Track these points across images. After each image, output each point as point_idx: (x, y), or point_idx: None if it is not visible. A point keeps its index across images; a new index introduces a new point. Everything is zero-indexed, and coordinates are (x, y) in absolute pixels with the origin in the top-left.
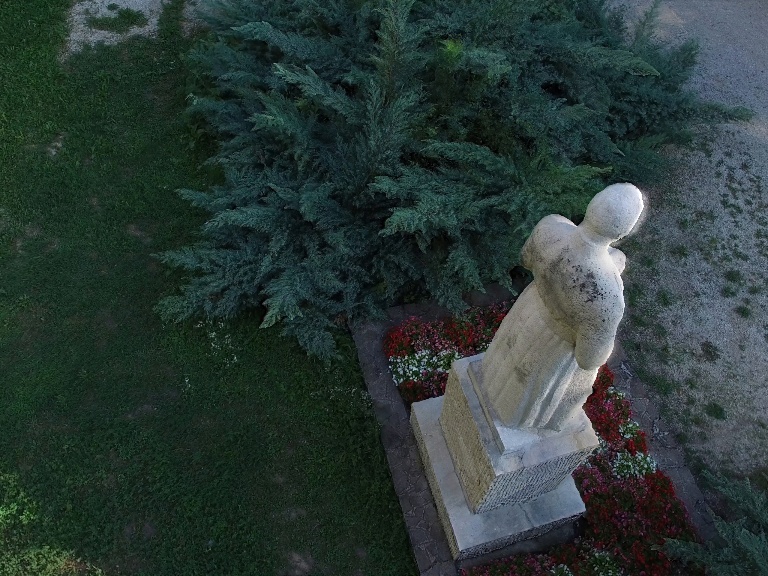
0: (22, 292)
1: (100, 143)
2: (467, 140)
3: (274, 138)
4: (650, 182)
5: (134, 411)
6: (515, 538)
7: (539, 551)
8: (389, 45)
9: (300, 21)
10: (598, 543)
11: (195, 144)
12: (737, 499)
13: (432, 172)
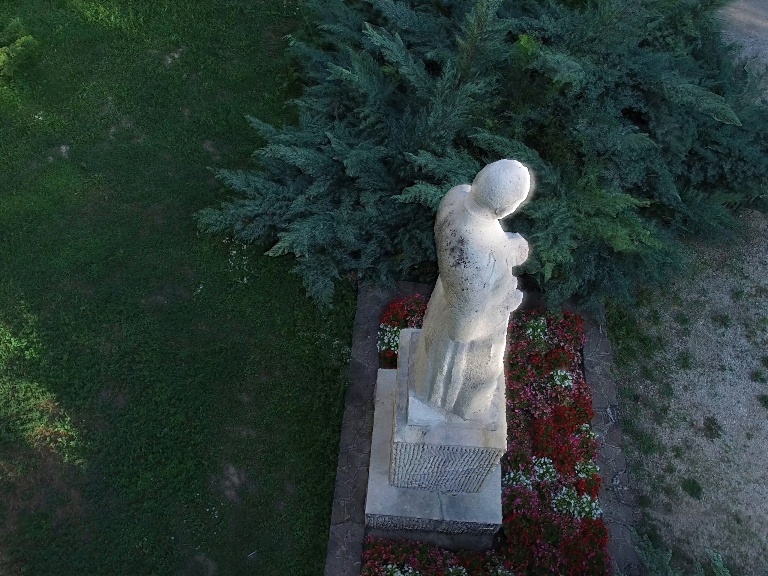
0: (99, 170)
1: (210, 63)
2: (529, 144)
3: None
4: (719, 243)
5: (148, 298)
6: (424, 523)
7: (450, 549)
8: (474, 30)
9: None
10: (508, 562)
11: (288, 85)
12: (650, 565)
13: (476, 161)
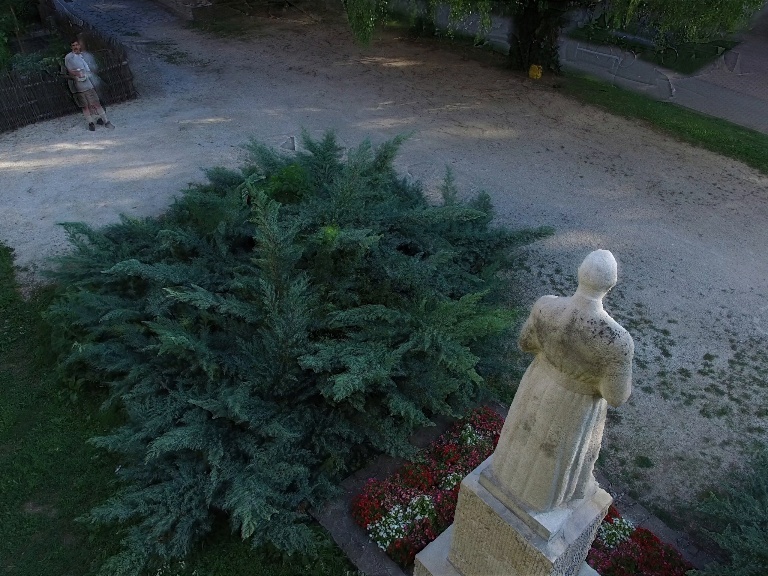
0: None
1: None
2: None
3: (169, 362)
4: (499, 303)
5: None
6: None
7: None
8: (268, 246)
9: (154, 255)
10: None
11: (77, 396)
12: (715, 512)
13: (344, 340)
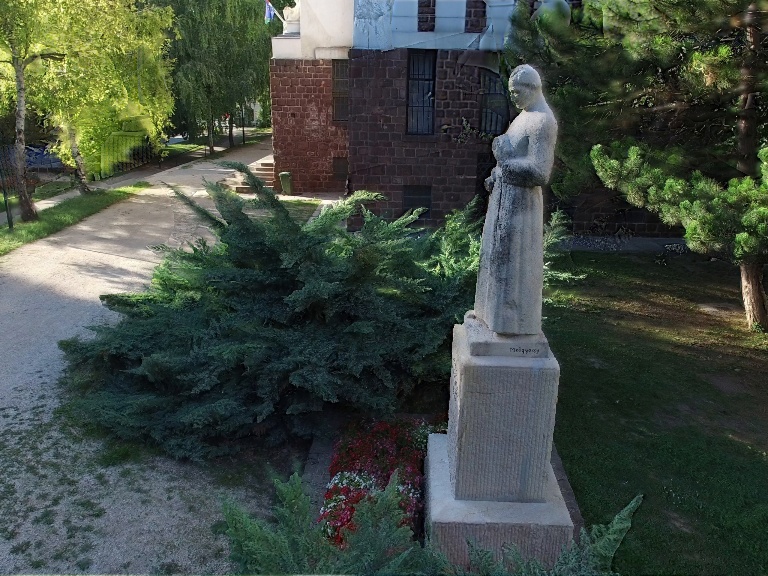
0: None
1: None
2: None
3: None
4: None
5: None
6: None
7: None
8: None
9: None
10: None
11: None
12: None
13: None
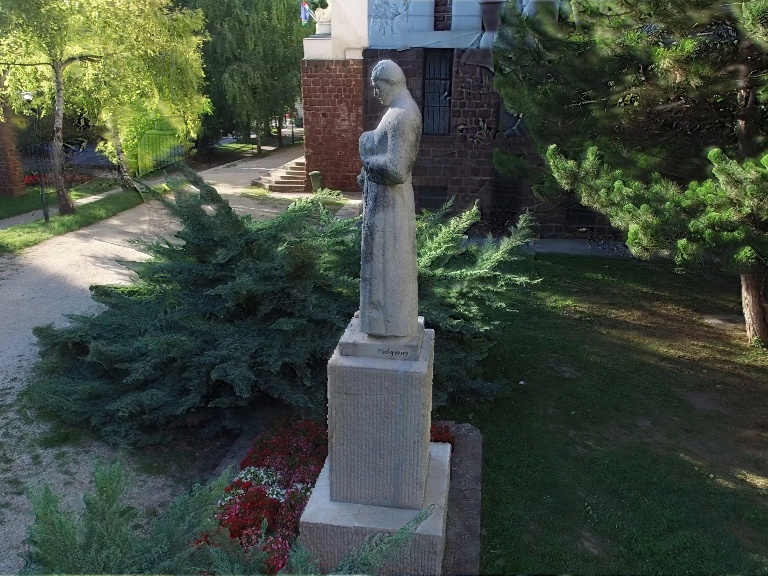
0: None
1: None
2: None
3: None
4: None
5: None
6: None
7: None
8: None
9: None
10: None
11: None
12: None
13: None
